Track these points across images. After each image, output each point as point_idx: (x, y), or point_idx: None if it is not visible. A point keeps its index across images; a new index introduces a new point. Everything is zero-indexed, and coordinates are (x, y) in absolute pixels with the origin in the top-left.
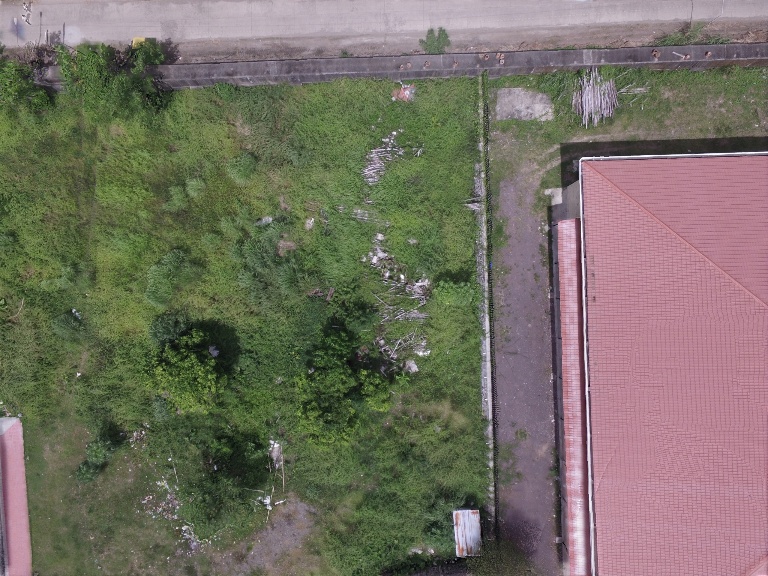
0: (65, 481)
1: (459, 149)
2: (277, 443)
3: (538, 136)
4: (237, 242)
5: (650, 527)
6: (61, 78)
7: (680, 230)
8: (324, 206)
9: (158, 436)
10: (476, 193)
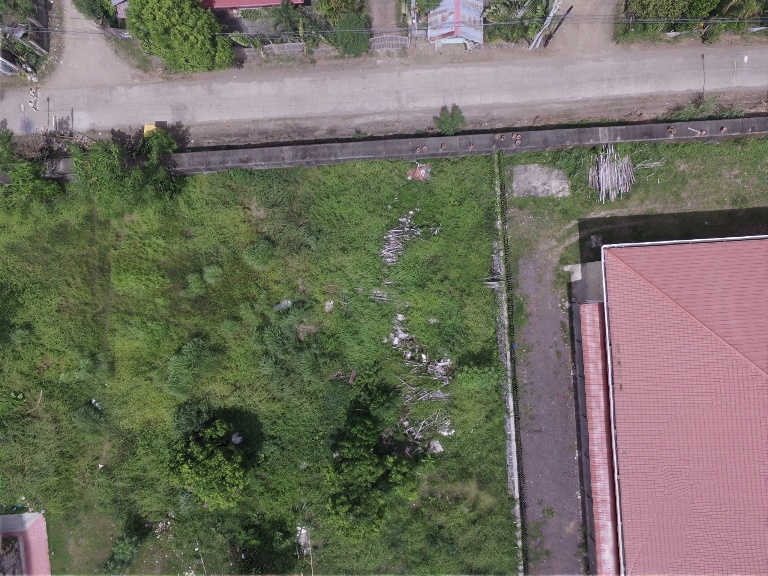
0: (91, 575)
1: (477, 227)
2: (304, 529)
3: (556, 212)
4: (257, 329)
5: None
6: (73, 171)
7: (705, 319)
8: (343, 289)
9: (184, 527)
10: (495, 270)
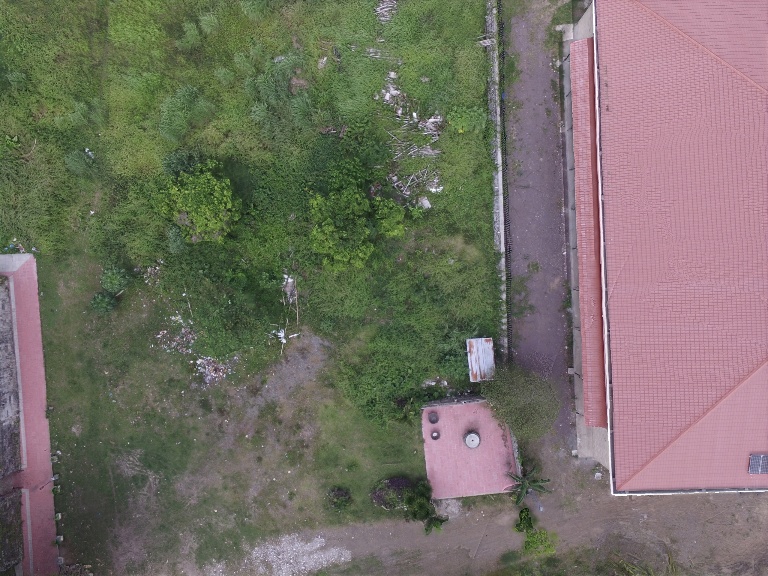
0: (79, 317)
1: None
2: (291, 278)
3: None
4: (250, 76)
5: (662, 335)
6: None
7: (692, 33)
8: (337, 43)
9: (172, 270)
10: (488, 31)
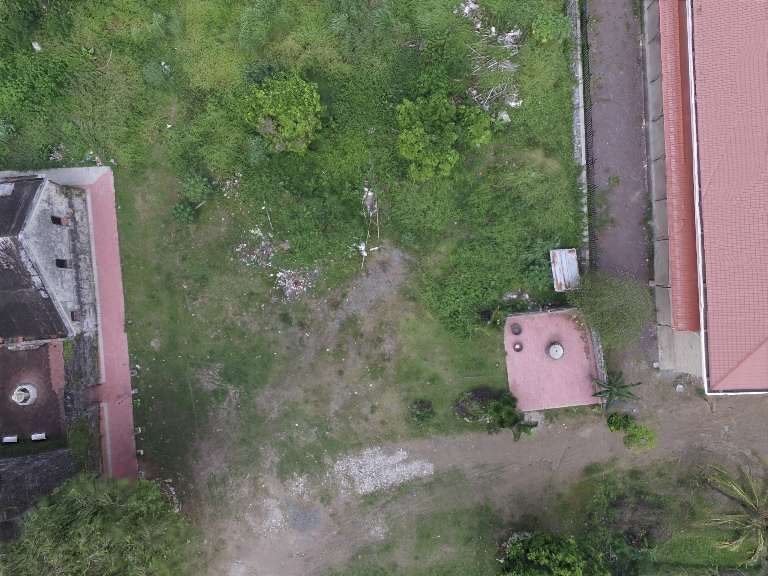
0: (157, 230)
1: None
2: (371, 191)
3: None
4: None
5: (754, 236)
6: None
7: None
8: None
9: (252, 183)
10: None
